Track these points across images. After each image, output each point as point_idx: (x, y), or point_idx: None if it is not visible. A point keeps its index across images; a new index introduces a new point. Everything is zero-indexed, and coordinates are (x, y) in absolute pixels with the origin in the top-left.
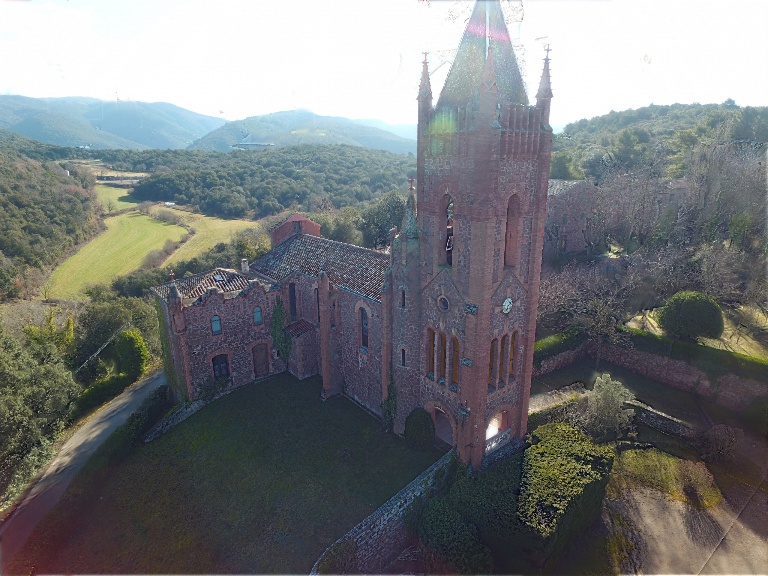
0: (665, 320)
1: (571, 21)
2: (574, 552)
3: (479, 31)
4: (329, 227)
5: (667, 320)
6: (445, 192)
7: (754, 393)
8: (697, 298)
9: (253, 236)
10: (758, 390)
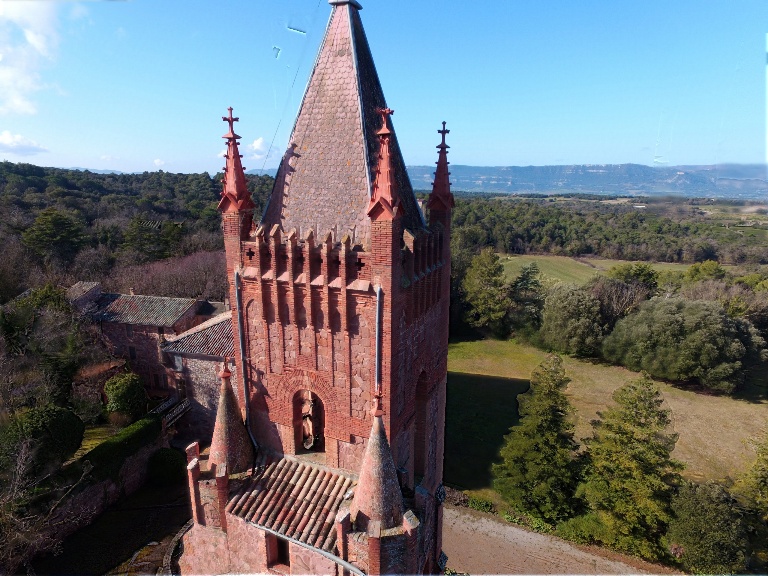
0: (37, 464)
1: (2, 9)
2: None
3: (378, 97)
4: None
5: (41, 461)
6: (421, 370)
7: (145, 459)
8: (53, 413)
9: None
10: (146, 453)
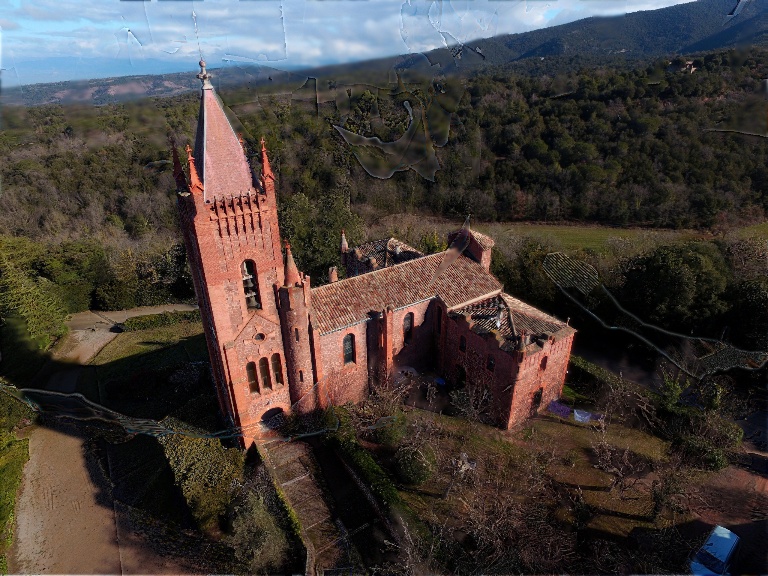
0: None
1: None
2: (179, 494)
3: None
4: (662, 273)
5: None
6: None
7: None
8: None
9: (550, 240)
10: None
